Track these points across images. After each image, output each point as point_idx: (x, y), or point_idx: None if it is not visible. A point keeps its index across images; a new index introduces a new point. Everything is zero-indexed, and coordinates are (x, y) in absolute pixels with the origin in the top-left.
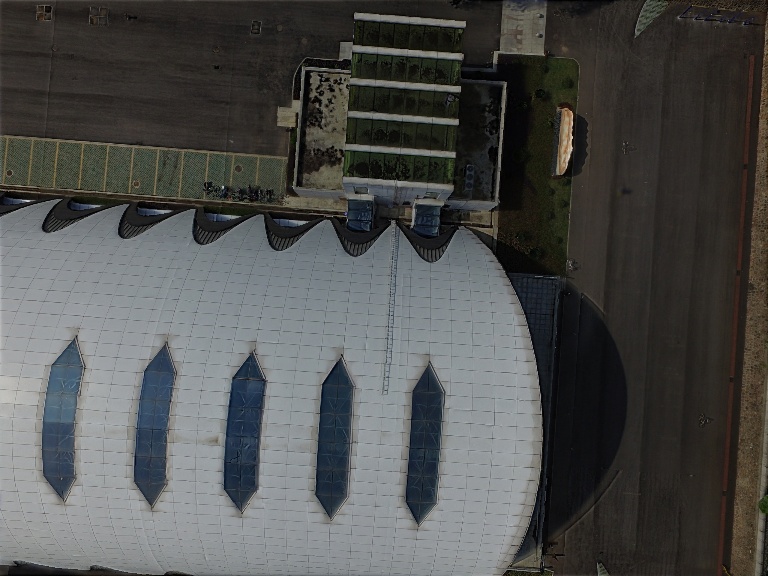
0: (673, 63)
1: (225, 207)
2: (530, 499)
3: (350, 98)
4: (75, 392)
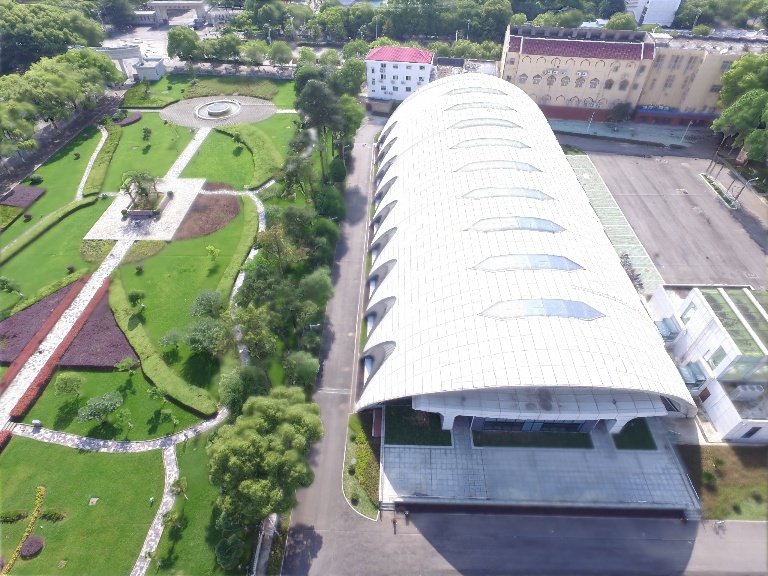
0: None
1: None
2: (526, 381)
3: (757, 291)
4: None
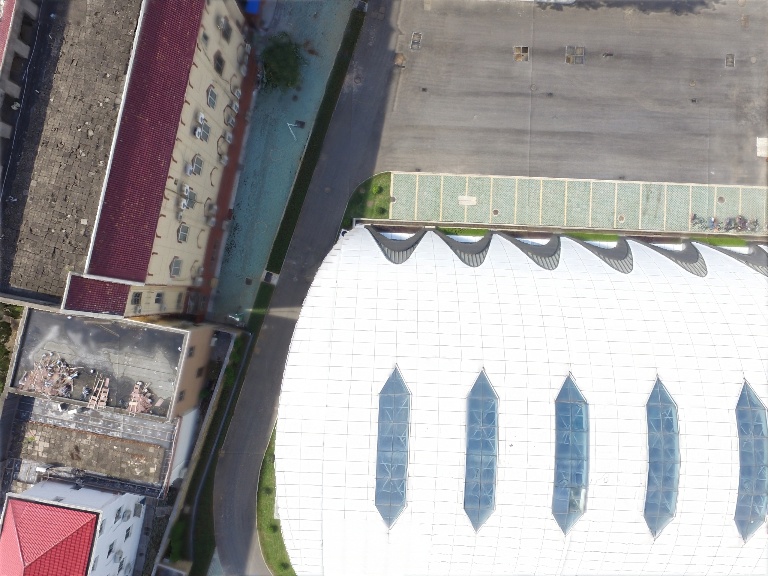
0: None
1: (712, 238)
2: None
3: None
4: (762, 435)
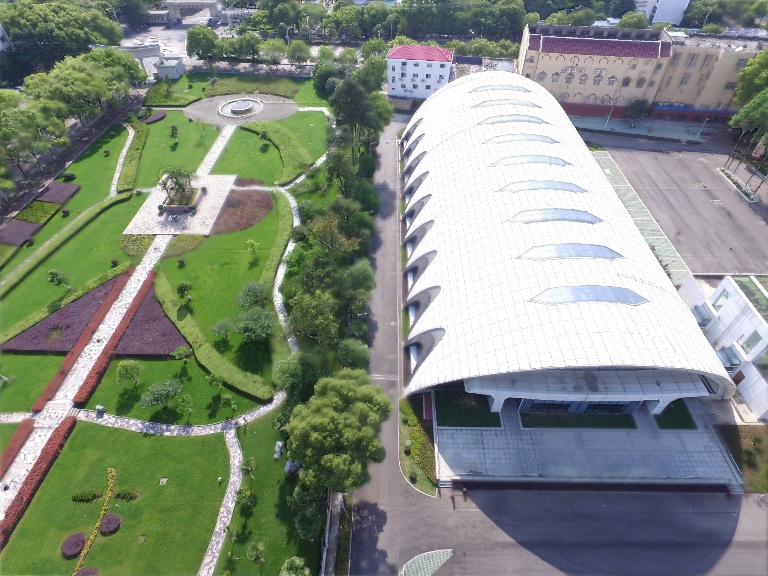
0: None
1: None
2: (583, 362)
3: None
4: None
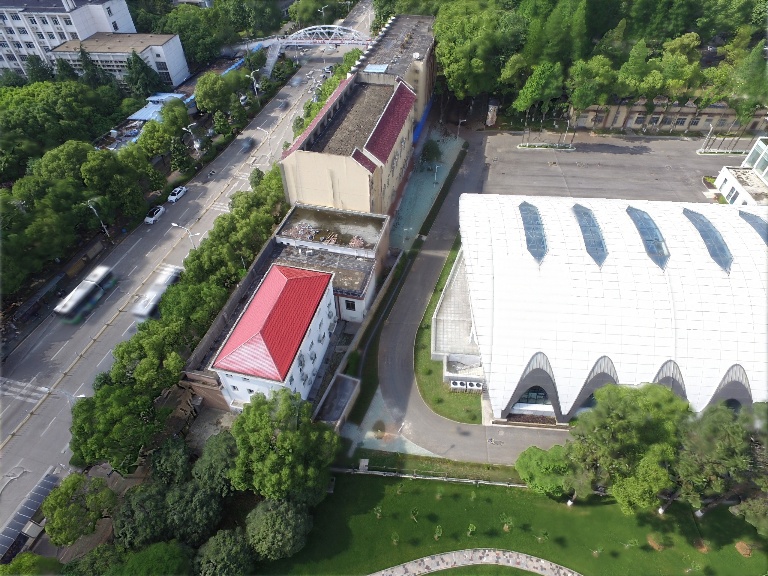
0: None
1: None
2: None
3: None
4: None
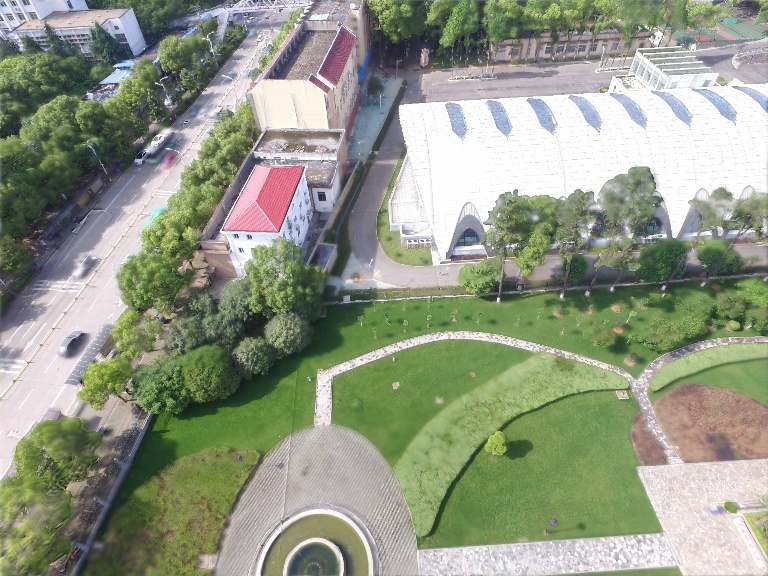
0: (760, 72)
1: None
2: None
3: None
4: None
